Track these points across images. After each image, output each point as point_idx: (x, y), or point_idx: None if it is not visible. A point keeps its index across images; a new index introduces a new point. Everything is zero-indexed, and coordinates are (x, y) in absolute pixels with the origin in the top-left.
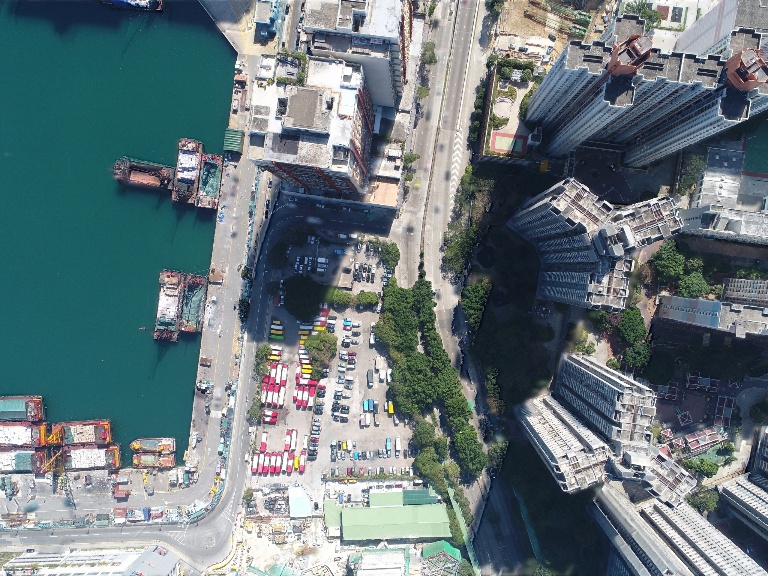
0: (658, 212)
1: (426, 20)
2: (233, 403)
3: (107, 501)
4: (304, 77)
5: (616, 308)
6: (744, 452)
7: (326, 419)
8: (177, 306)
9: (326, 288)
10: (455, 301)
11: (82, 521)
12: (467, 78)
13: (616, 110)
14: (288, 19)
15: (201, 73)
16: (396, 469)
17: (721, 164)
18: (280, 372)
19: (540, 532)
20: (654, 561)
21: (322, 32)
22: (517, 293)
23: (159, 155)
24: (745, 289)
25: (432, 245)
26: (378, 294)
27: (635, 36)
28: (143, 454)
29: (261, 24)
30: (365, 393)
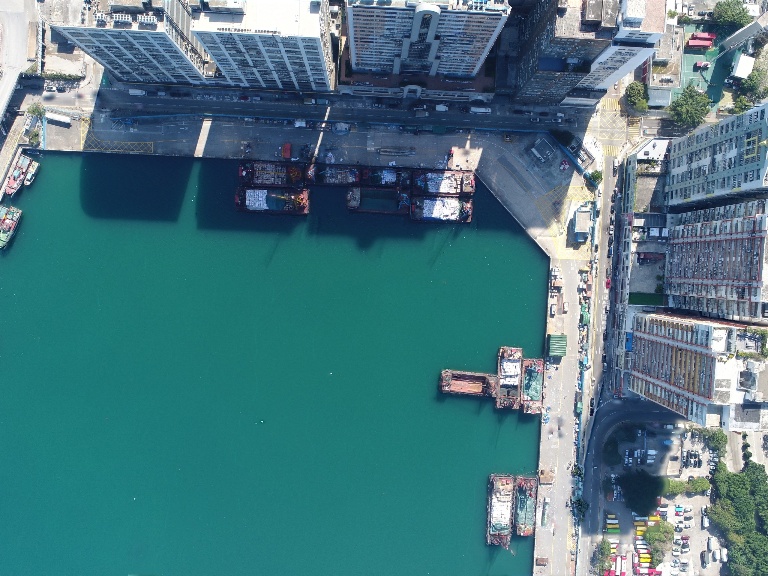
0: None
1: None
2: None
3: None
4: None
5: None
6: None
7: None
8: None
9: (662, 481)
10: None
11: None
12: None
13: None
14: (599, 222)
15: (513, 279)
16: None
17: None
18: (620, 564)
19: None
20: None
21: None
22: None
23: (477, 363)
24: None
25: None
26: (706, 478)
27: None
28: None
29: (578, 232)
30: (700, 573)
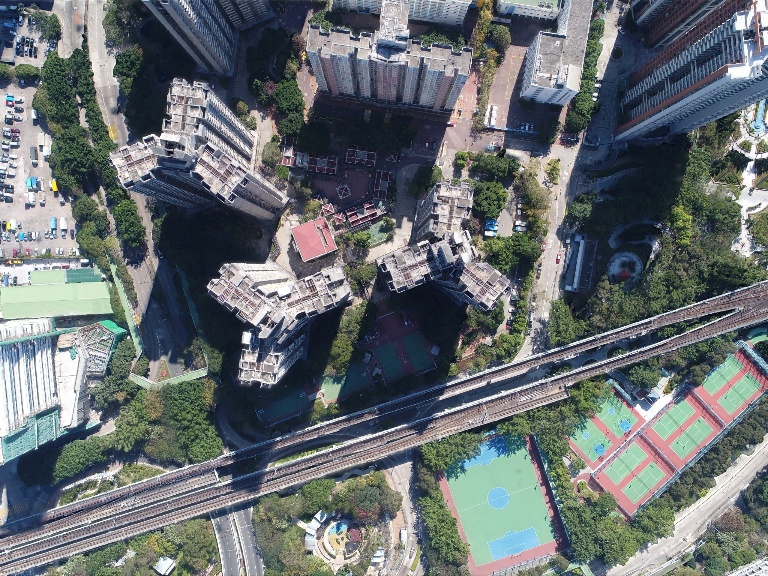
0: None
1: None
2: None
3: None
4: None
5: None
6: (405, 228)
7: None
8: None
9: None
10: None
11: None
12: None
13: None
14: None
15: None
16: (63, 250)
17: None
18: None
19: (200, 305)
20: None
21: None
22: (174, 63)
23: None
24: None
25: (96, 19)
26: (41, 69)
27: None
28: None
29: None
30: (30, 172)
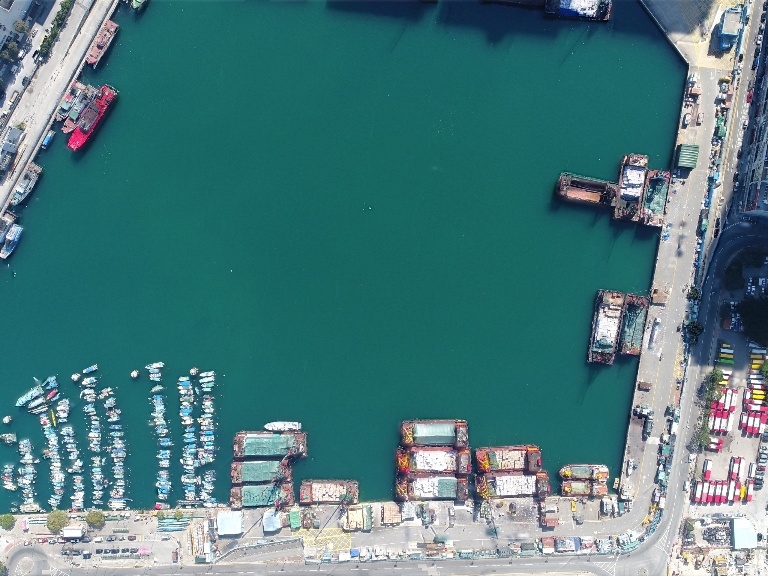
0: None
1: None
2: (676, 429)
3: (531, 530)
4: None
5: None
6: None
7: None
8: None
9: None
10: None
11: (508, 551)
12: None
13: None
14: (746, 30)
15: (646, 86)
16: None
17: None
18: (730, 398)
19: None
20: None
21: None
22: None
23: (597, 170)
24: None
25: None
26: None
27: None
28: (573, 481)
29: (724, 35)
30: None
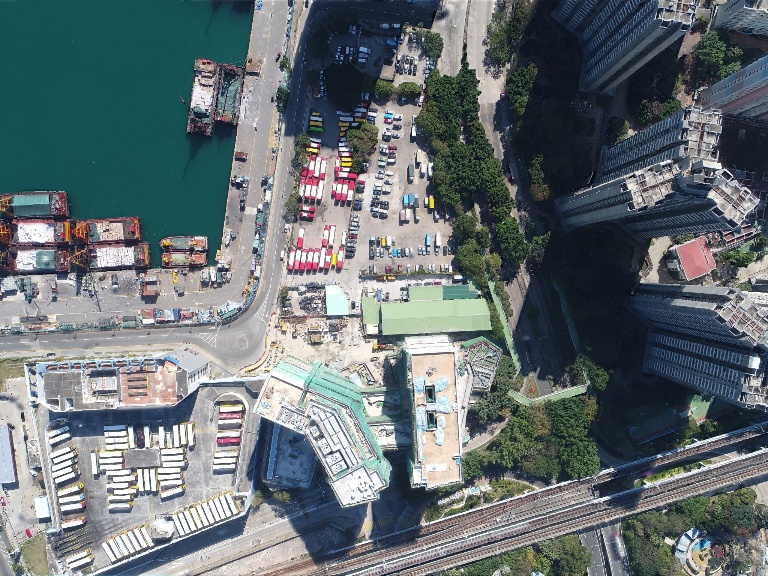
0: None
1: None
2: (269, 197)
3: (134, 302)
4: None
5: (685, 25)
6: None
7: (365, 215)
8: (212, 97)
9: (368, 76)
10: (497, 95)
11: (108, 322)
12: None
13: None
14: None
15: None
16: (435, 266)
17: None
18: (319, 165)
19: (580, 323)
20: (713, 292)
21: None
22: (561, 82)
23: None
24: None
25: (475, 38)
26: (420, 86)
27: None
28: (173, 253)
29: None
30: (405, 189)
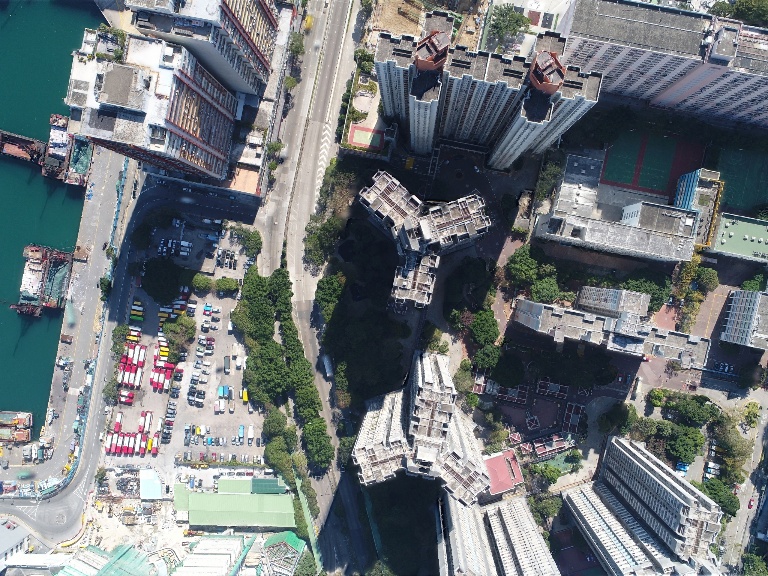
0: (465, 210)
1: (299, 11)
2: (90, 381)
3: None
4: (122, 54)
5: (420, 303)
6: (592, 460)
7: (182, 403)
8: (41, 281)
9: (186, 272)
10: None
11: None
12: (338, 71)
13: (425, 105)
14: None
15: None
16: (248, 457)
17: (579, 171)
18: (138, 353)
19: (382, 528)
20: (453, 559)
21: (145, 11)
22: (373, 288)
23: (33, 129)
24: (590, 296)
25: (296, 235)
26: (239, 281)
27: (434, 32)
28: None
29: None
30: (222, 379)
